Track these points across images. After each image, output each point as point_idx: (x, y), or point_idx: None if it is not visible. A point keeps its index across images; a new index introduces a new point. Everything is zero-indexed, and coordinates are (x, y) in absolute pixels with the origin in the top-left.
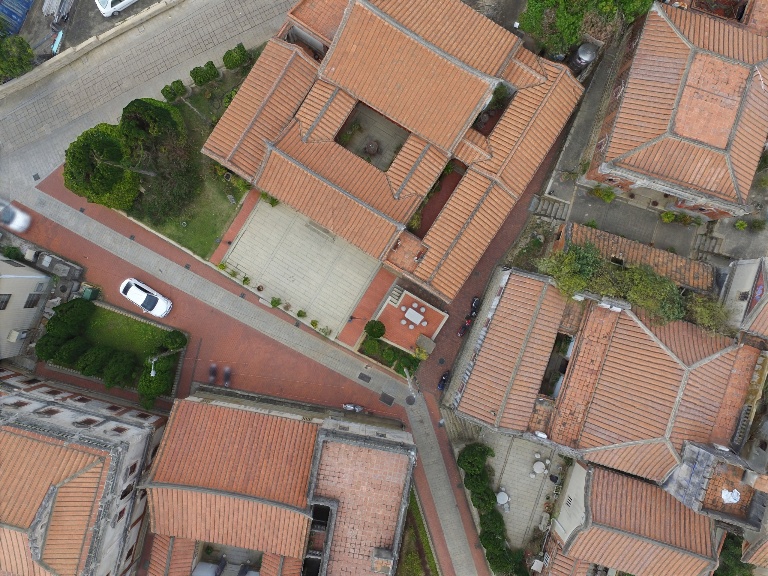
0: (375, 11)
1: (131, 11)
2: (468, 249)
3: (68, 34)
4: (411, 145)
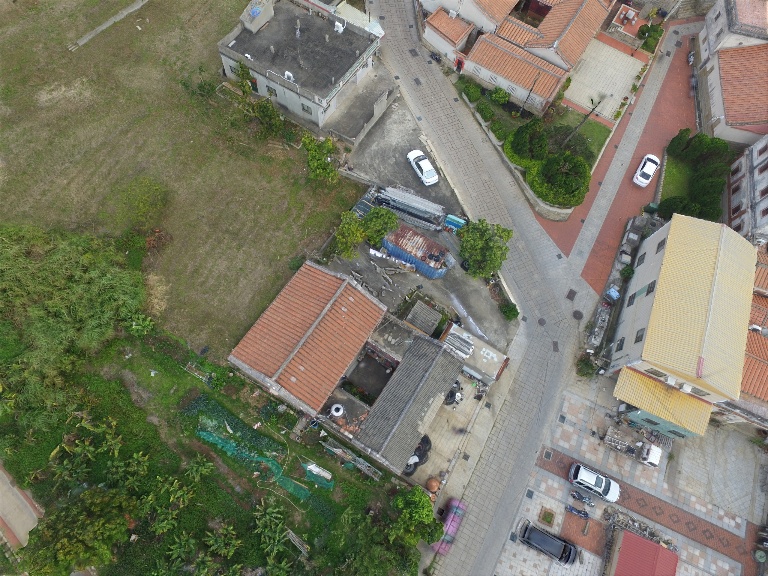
0: None
1: None
2: None
3: None
4: None
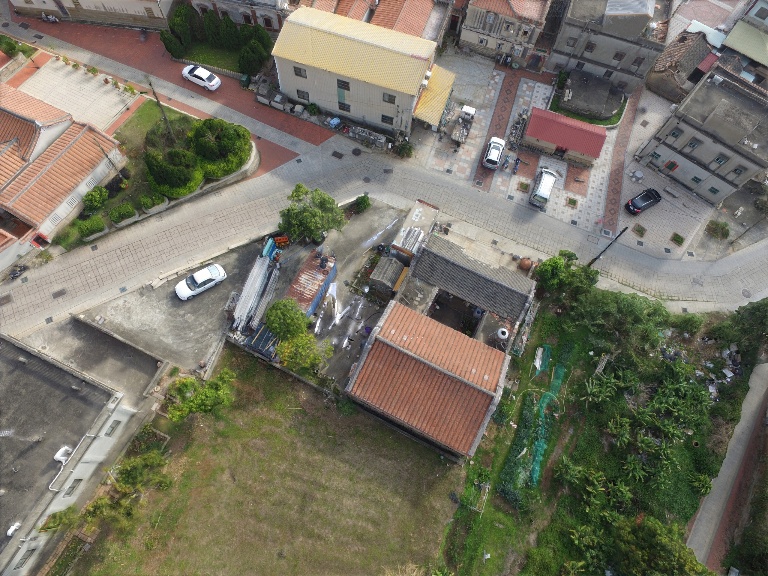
0: None
1: None
2: None
3: None
4: None
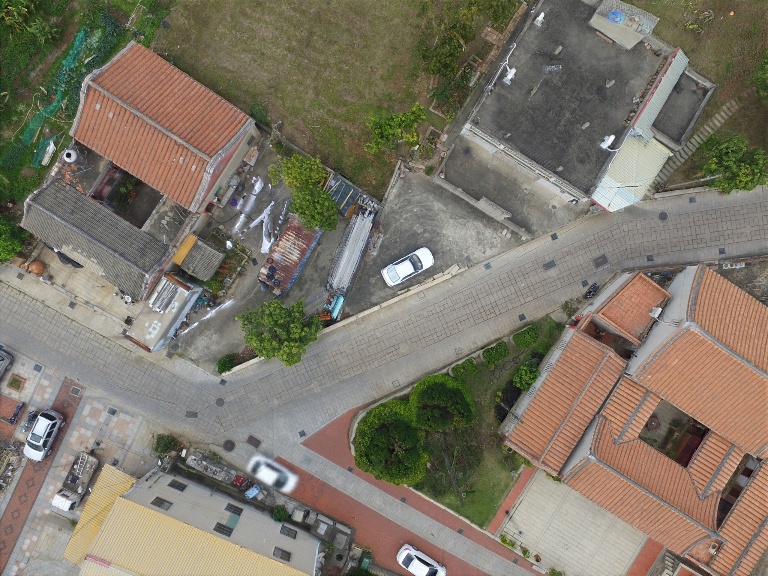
0: (709, 338)
1: (413, 279)
2: (761, 541)
3: (348, 300)
4: (713, 443)
